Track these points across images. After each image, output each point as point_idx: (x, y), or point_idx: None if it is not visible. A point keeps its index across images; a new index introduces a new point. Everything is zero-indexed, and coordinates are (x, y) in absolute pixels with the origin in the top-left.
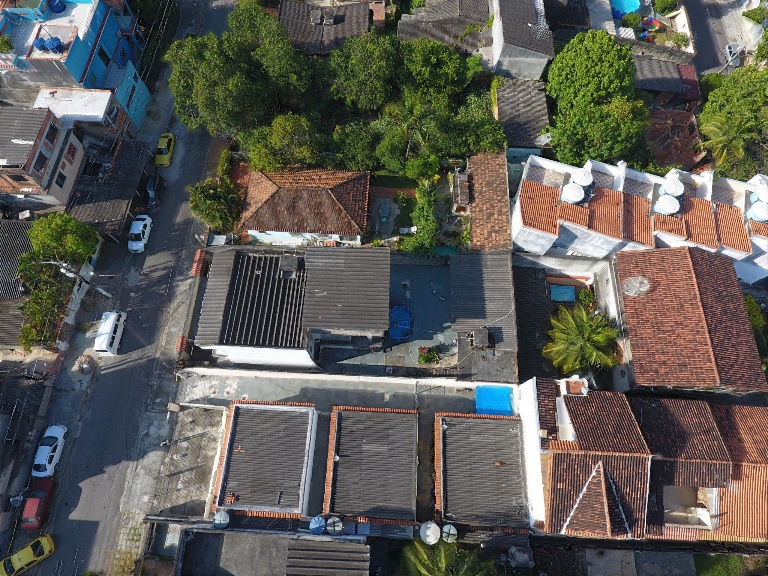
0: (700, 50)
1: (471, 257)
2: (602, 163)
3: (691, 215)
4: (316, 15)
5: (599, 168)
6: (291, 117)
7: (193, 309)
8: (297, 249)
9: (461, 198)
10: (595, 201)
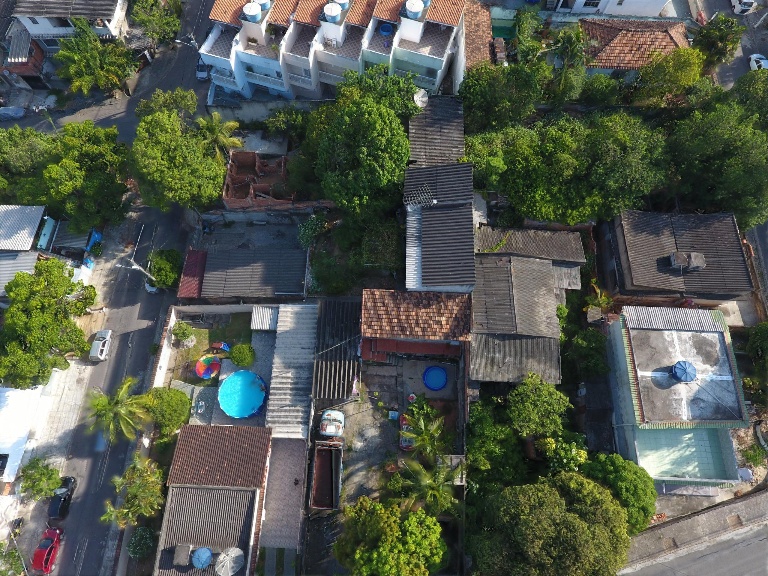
0: (137, 362)
1: (491, 2)
2: (379, 53)
3: (319, 2)
4: (698, 258)
5: (378, 58)
6: (684, 72)
7: (689, 1)
8: (629, 16)
9: (502, 39)
10: (401, 3)
